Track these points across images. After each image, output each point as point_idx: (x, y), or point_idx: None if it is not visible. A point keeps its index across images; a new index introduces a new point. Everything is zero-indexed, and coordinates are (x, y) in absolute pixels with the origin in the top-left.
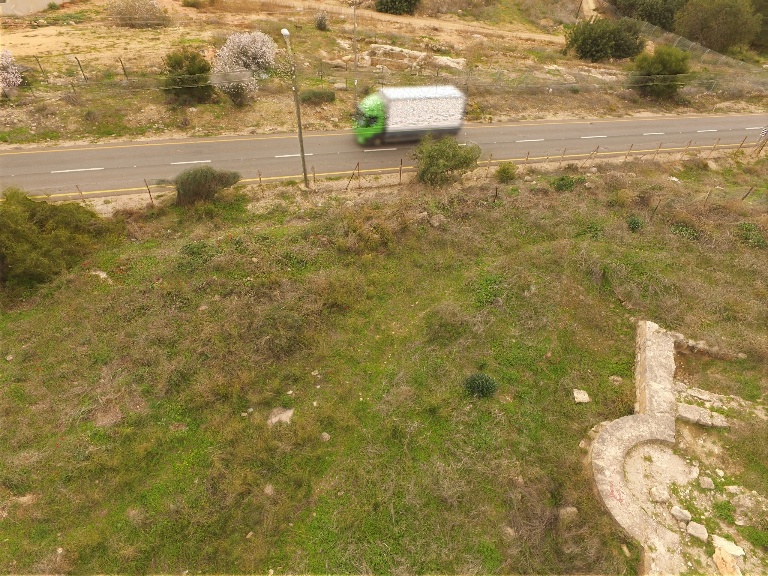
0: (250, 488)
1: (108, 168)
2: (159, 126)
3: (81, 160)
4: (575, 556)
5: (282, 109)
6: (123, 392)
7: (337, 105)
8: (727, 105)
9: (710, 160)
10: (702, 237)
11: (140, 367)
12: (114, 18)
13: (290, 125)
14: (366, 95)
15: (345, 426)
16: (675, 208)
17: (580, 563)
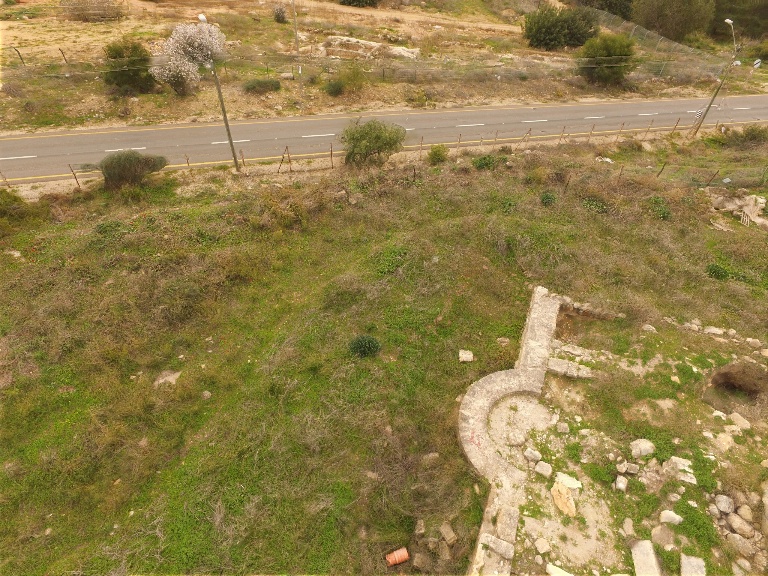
0: (123, 440)
1: (41, 156)
2: (99, 116)
3: (15, 149)
4: (427, 494)
5: (226, 98)
6: (17, 359)
7: (282, 94)
8: (674, 90)
9: (646, 142)
10: (610, 210)
11: (37, 336)
12: (48, 8)
13: (233, 113)
14: (312, 84)
15: (227, 385)
16: (588, 183)
17: (430, 500)
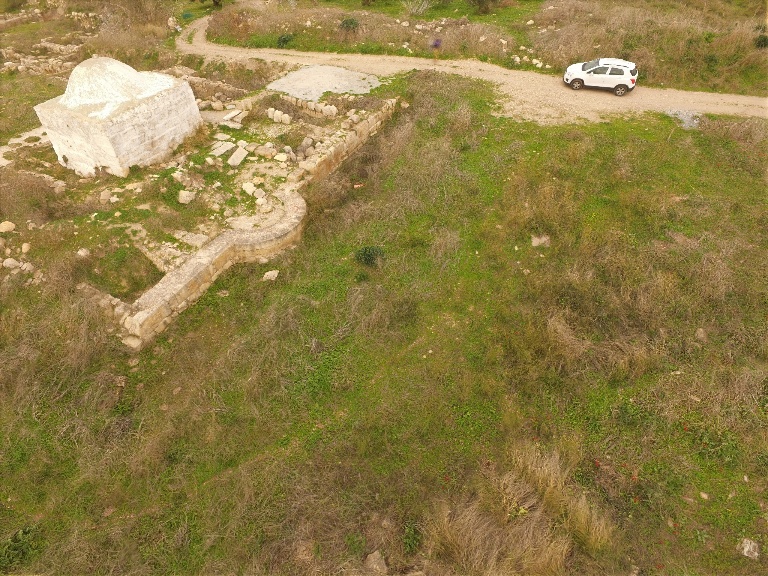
0: None
1: None
2: None
3: None
4: None
5: None
6: None
7: None
8: None
9: None
10: None
11: None
12: None
13: None
14: None
15: None
16: None
17: None
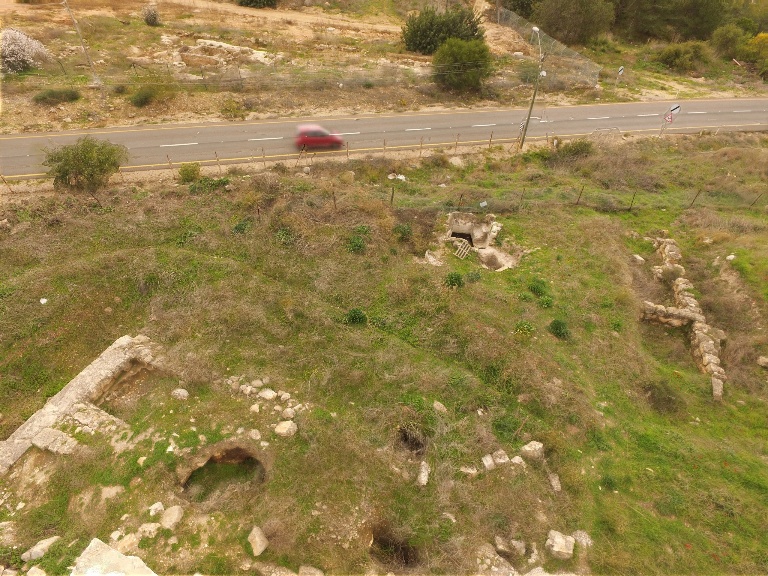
0: None
1: None
2: None
3: None
4: None
5: (9, 110)
6: None
7: (77, 105)
8: None
9: (457, 156)
10: (296, 242)
11: None
12: None
13: (11, 126)
14: (120, 93)
15: None
16: (291, 211)
17: None
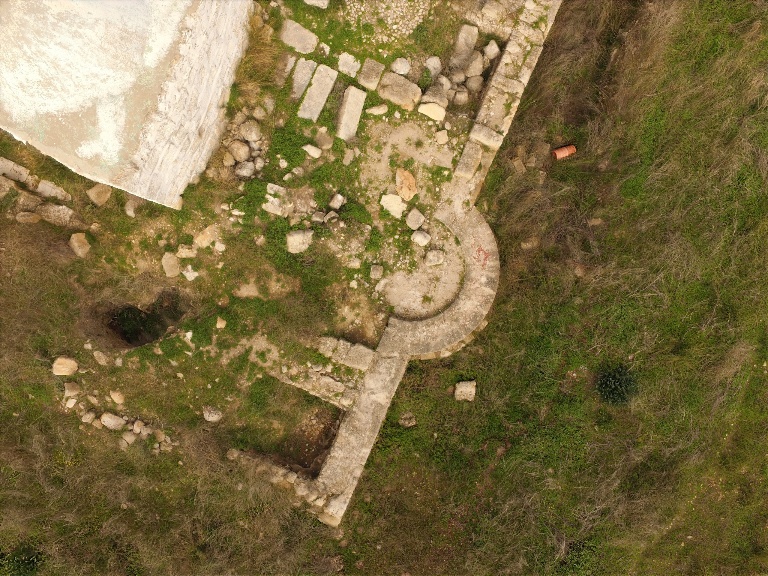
0: None
1: None
2: None
3: None
4: None
5: None
6: None
7: None
8: None
9: None
10: None
11: None
12: None
13: None
14: None
15: None
16: None
17: None
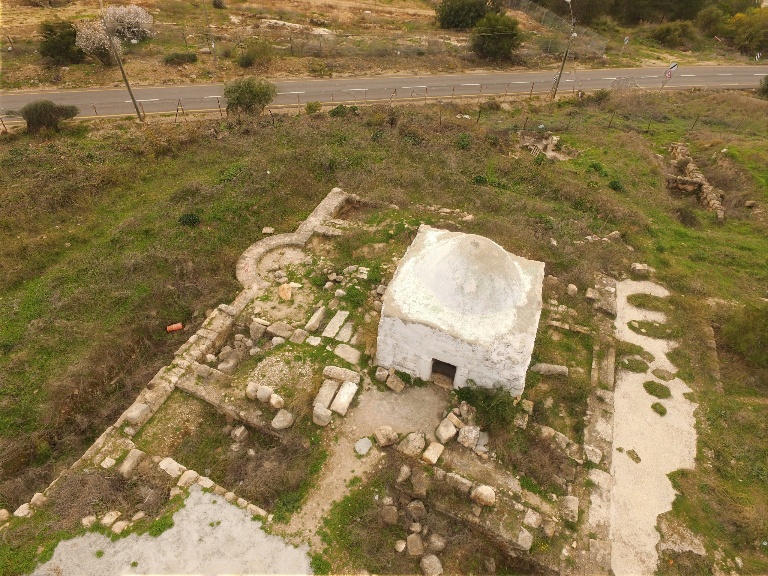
0: None
1: None
2: (34, 81)
3: None
4: None
5: (147, 68)
6: None
7: (198, 65)
8: (559, 64)
9: (506, 103)
10: (422, 143)
11: None
12: None
13: (152, 81)
14: (227, 57)
15: (83, 239)
16: (412, 124)
17: None
